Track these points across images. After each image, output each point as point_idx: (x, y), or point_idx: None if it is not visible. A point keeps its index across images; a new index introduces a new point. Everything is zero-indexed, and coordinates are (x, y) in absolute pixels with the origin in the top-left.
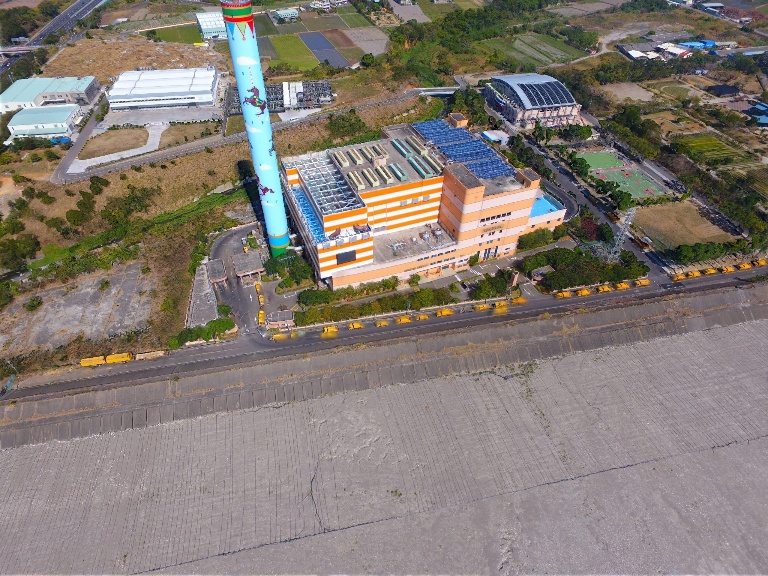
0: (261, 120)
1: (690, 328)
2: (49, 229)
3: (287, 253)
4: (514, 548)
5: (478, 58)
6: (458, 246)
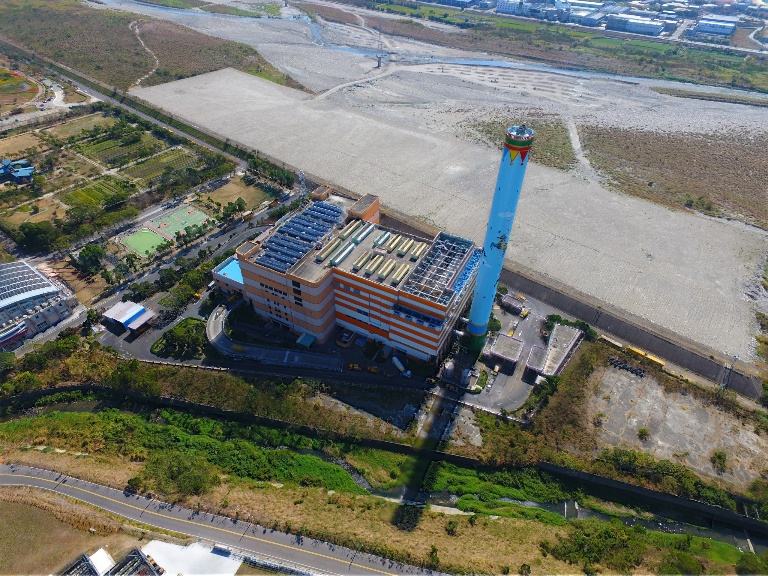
0: None
1: None
2: None
3: None
4: None
5: None
6: None
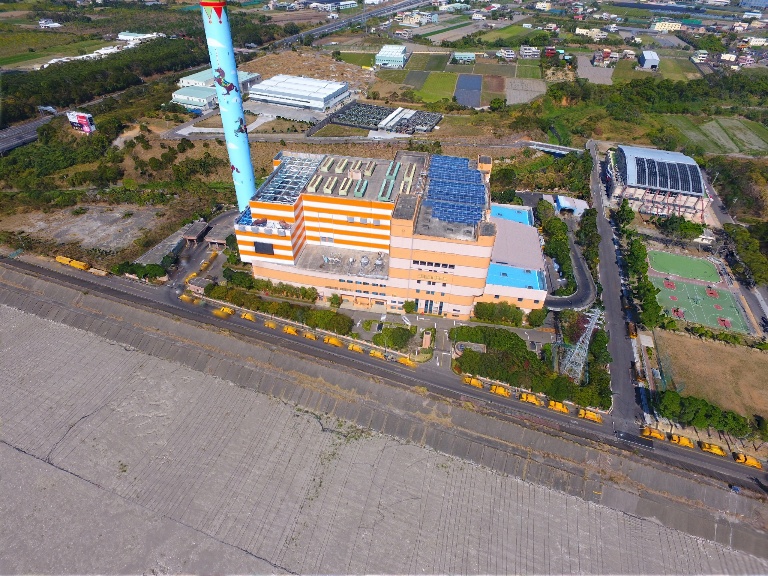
0: (227, 100)
1: (606, 500)
2: None
3: None
4: None
5: (637, 129)
6: (388, 282)
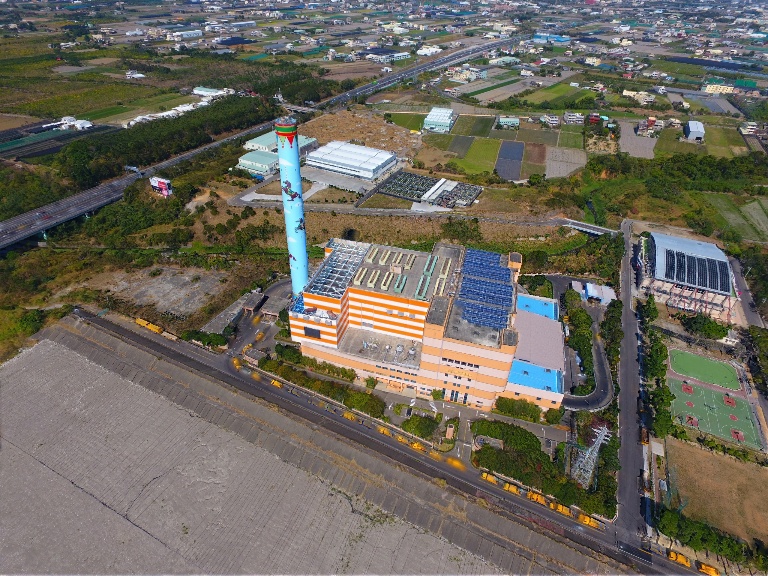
0: (291, 205)
1: None
2: (204, 231)
3: None
4: None
5: (675, 208)
6: (419, 372)
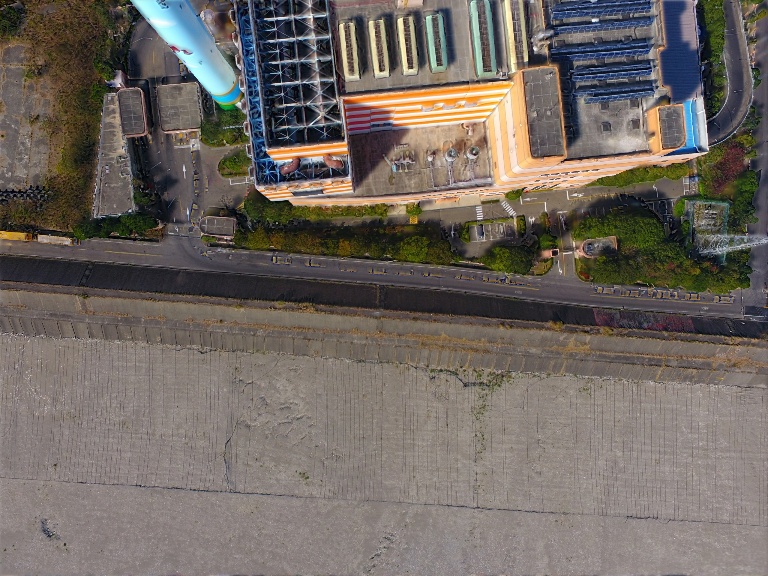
0: None
1: (726, 381)
2: None
3: (236, 113)
4: (390, 547)
5: None
6: (493, 187)
